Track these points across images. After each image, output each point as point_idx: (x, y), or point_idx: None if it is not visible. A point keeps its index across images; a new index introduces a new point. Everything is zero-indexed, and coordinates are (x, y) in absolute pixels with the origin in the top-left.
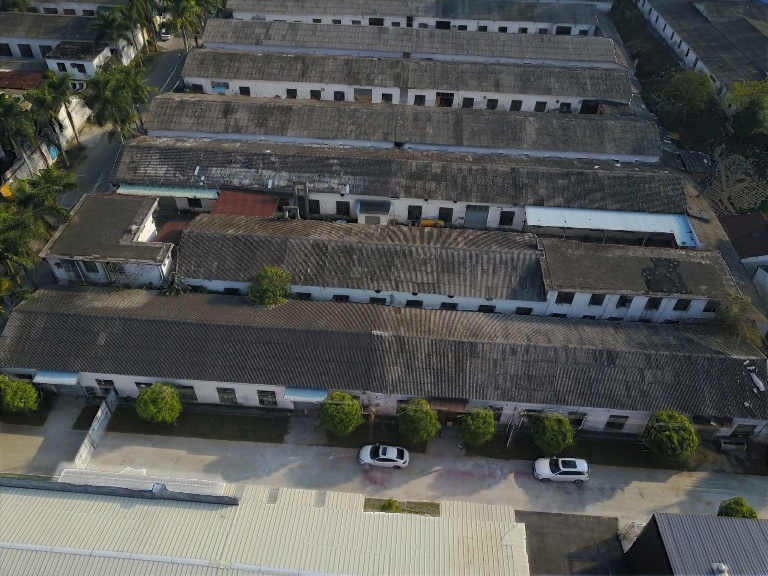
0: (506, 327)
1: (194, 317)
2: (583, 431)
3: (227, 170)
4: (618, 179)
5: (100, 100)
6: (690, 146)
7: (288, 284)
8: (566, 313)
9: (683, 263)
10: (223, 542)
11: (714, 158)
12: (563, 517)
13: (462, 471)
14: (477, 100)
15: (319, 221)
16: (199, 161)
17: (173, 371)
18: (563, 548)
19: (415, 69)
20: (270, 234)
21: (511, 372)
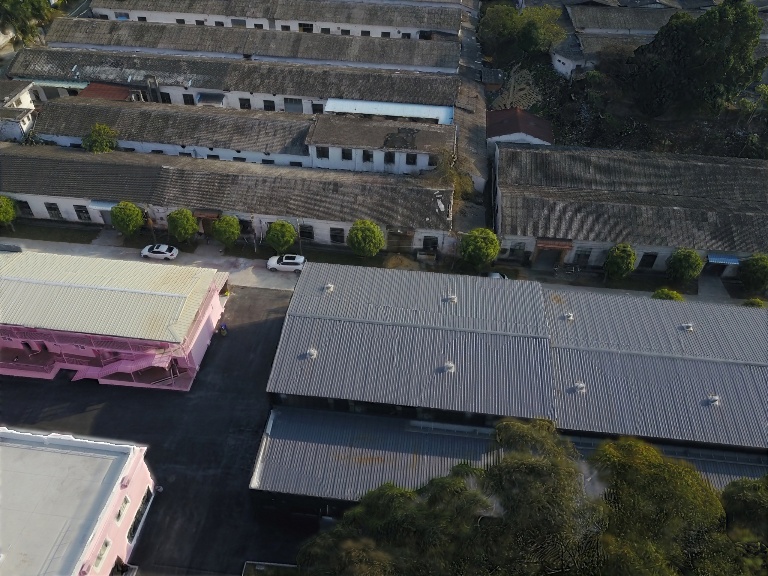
0: (270, 169)
1: (35, 155)
2: (317, 244)
3: (98, 68)
4: (407, 80)
5: (1, 11)
6: (497, 67)
7: (115, 139)
8: (328, 167)
9: (422, 131)
10: (1, 267)
11: (510, 74)
12: (277, 291)
13: (215, 264)
14: (333, 30)
15: (158, 103)
16: (77, 61)
17: (11, 188)
18: (267, 306)
19: (283, 4)
20: (110, 106)
21: (258, 194)
